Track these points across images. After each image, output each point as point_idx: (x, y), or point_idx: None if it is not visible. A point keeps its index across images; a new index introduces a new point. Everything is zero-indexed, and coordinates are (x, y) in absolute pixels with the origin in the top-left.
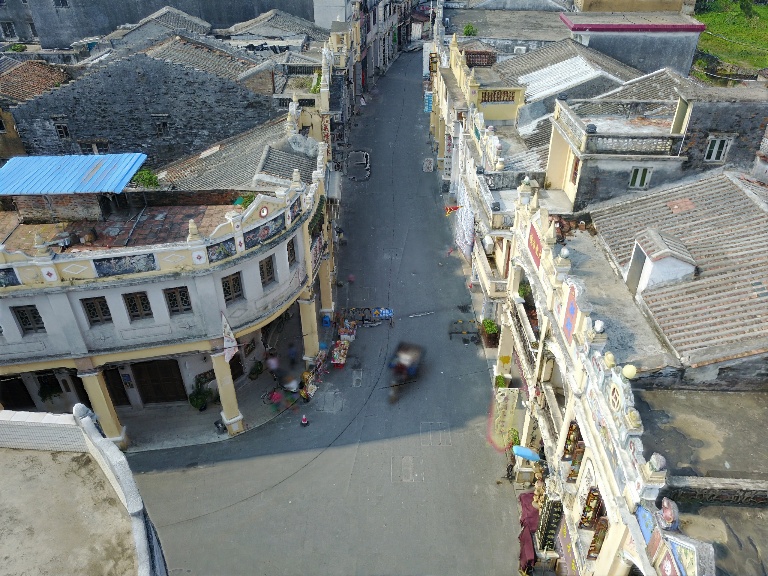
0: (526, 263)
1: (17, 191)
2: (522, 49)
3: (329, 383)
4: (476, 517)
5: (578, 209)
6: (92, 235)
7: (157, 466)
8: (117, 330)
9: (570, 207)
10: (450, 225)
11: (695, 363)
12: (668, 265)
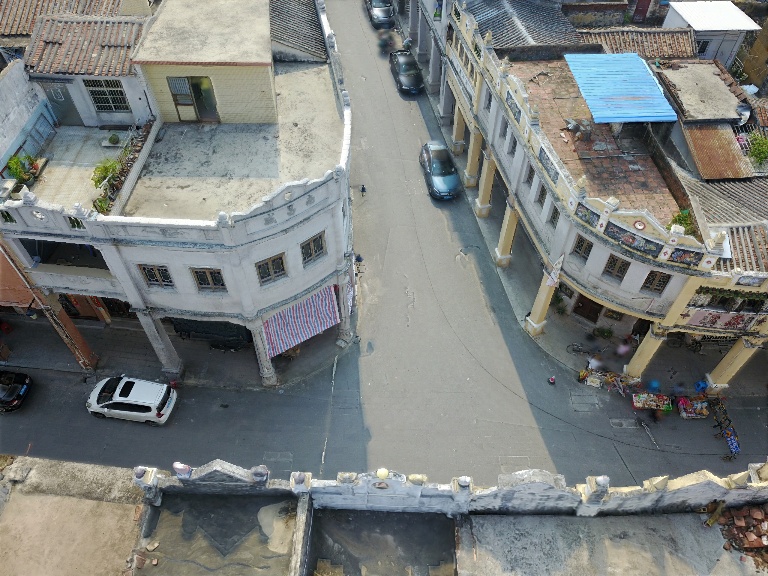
0: None
1: (576, 73)
2: None
3: (609, 398)
4: None
5: None
6: (583, 136)
7: (488, 288)
8: (529, 198)
9: None
10: None
11: None
12: None
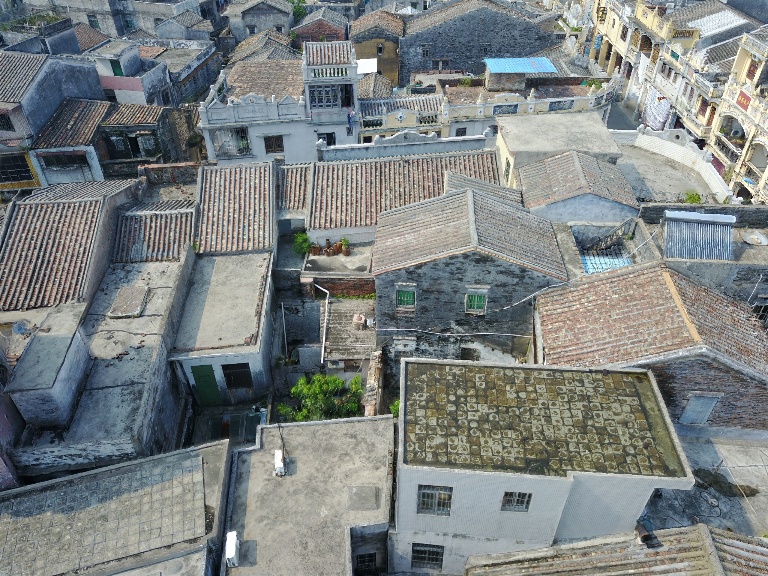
0: (737, 109)
1: (513, 71)
2: (672, 5)
3: None
4: None
5: None
6: None
7: None
8: None
9: None
10: (629, 120)
11: None
12: None
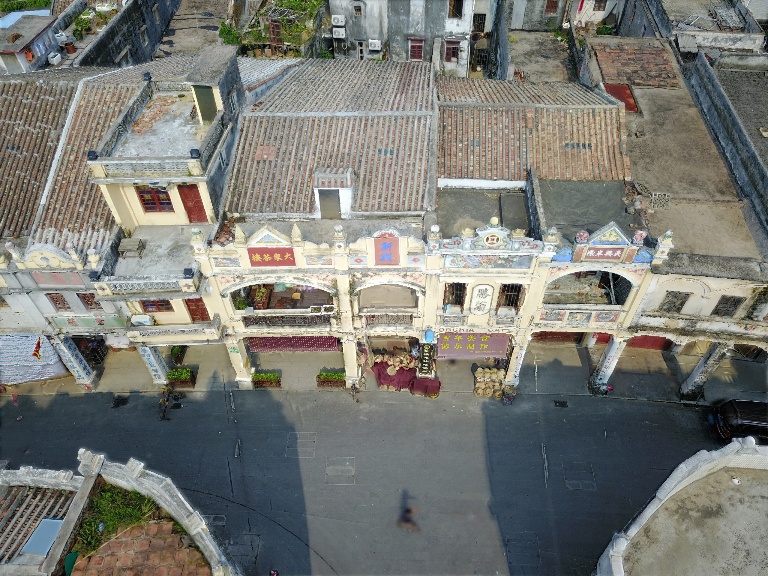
0: None
1: None
2: None
3: None
4: (390, 421)
5: (217, 217)
6: None
7: None
8: None
9: (173, 228)
10: None
11: (435, 205)
12: (352, 182)
